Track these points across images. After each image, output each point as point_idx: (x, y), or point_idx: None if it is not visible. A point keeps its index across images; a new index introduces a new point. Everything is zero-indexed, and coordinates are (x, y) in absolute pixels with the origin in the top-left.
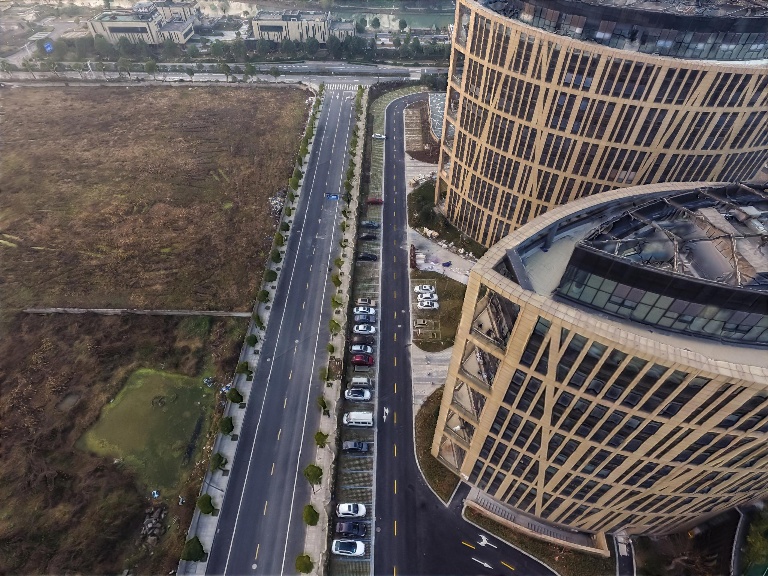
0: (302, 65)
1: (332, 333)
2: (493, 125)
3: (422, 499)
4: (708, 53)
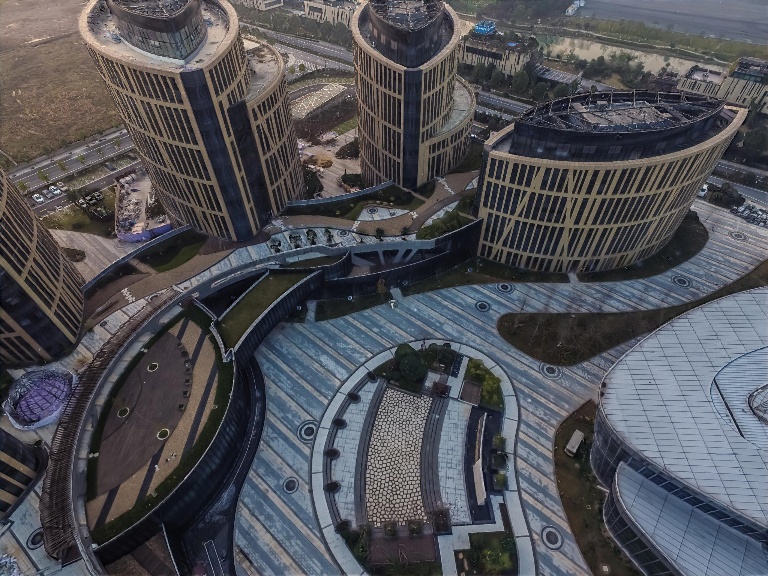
0: (314, 43)
1: None
2: None
3: None
4: (135, 41)
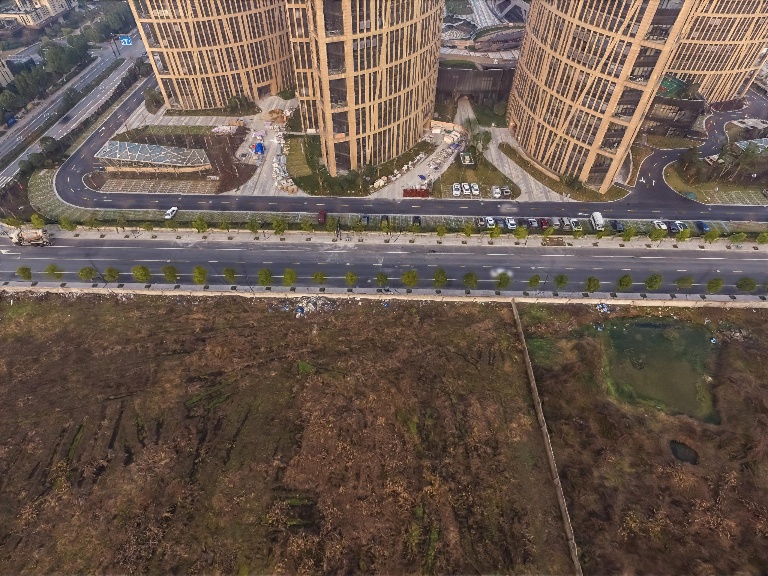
0: None
1: (528, 235)
2: (389, 43)
3: (633, 201)
4: None
